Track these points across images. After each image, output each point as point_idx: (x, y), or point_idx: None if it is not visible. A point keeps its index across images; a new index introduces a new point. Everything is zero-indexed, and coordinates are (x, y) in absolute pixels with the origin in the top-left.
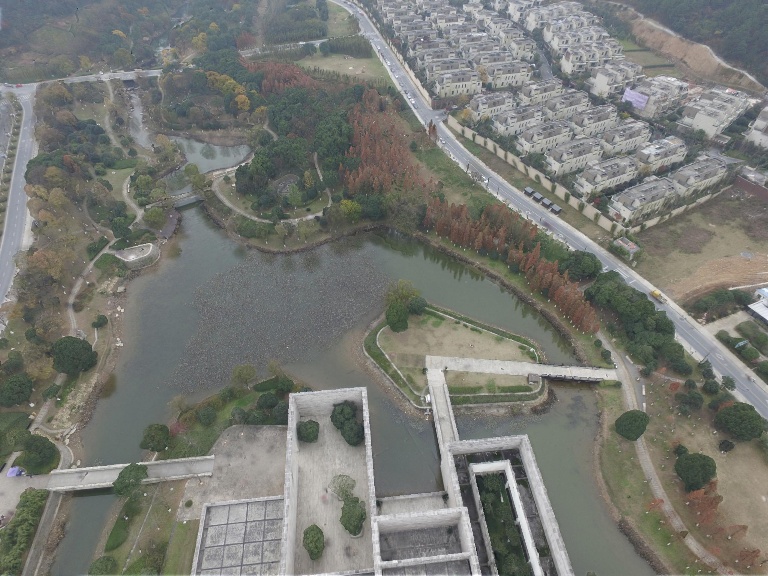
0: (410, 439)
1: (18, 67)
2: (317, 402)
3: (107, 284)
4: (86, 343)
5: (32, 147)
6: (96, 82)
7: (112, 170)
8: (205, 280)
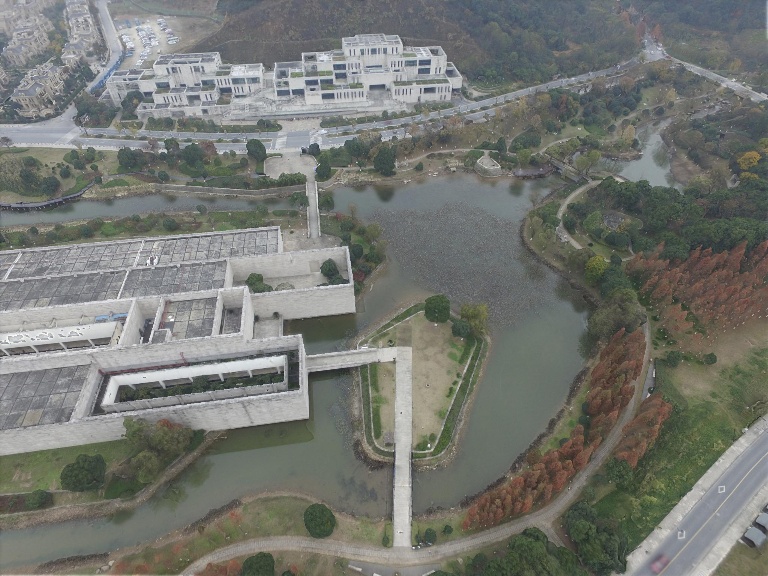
0: (331, 341)
1: (689, 45)
2: None
3: (456, 162)
4: (392, 161)
5: (588, 89)
6: (713, 82)
7: (582, 127)
8: (475, 204)
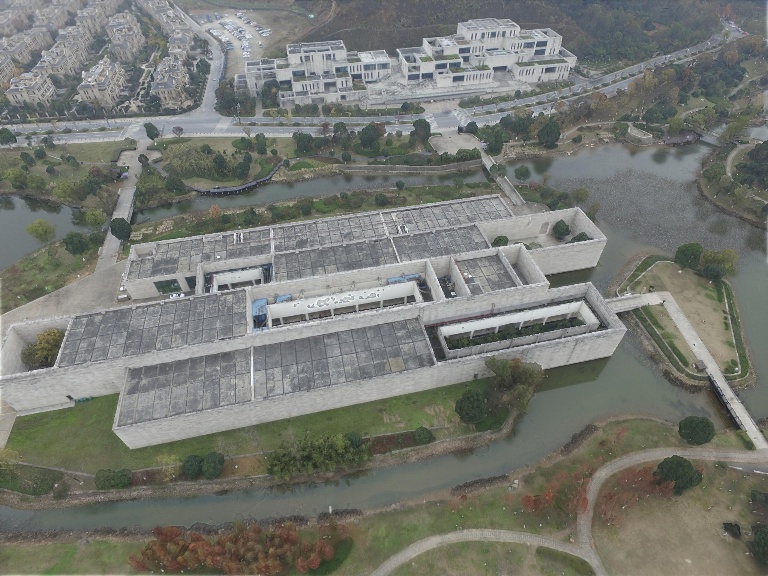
0: None
1: (762, 21)
2: (583, 226)
3: (605, 133)
4: (559, 134)
5: None
6: None
7: (704, 98)
8: (644, 170)
